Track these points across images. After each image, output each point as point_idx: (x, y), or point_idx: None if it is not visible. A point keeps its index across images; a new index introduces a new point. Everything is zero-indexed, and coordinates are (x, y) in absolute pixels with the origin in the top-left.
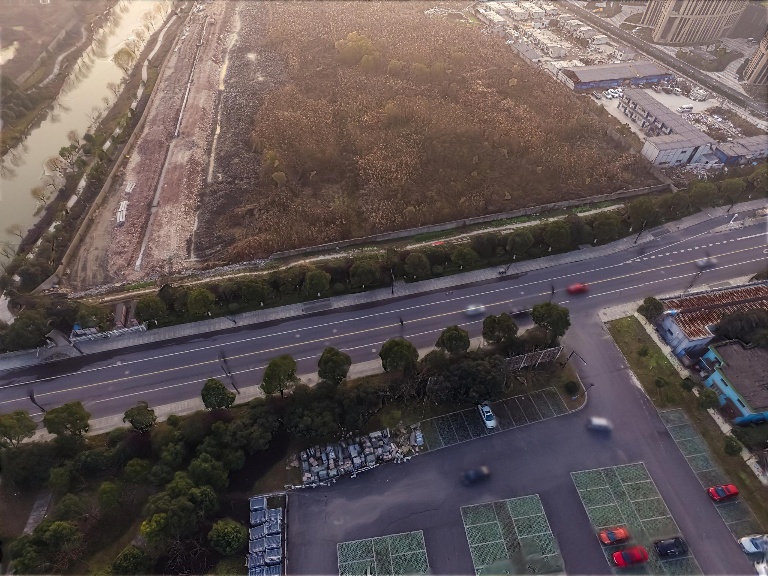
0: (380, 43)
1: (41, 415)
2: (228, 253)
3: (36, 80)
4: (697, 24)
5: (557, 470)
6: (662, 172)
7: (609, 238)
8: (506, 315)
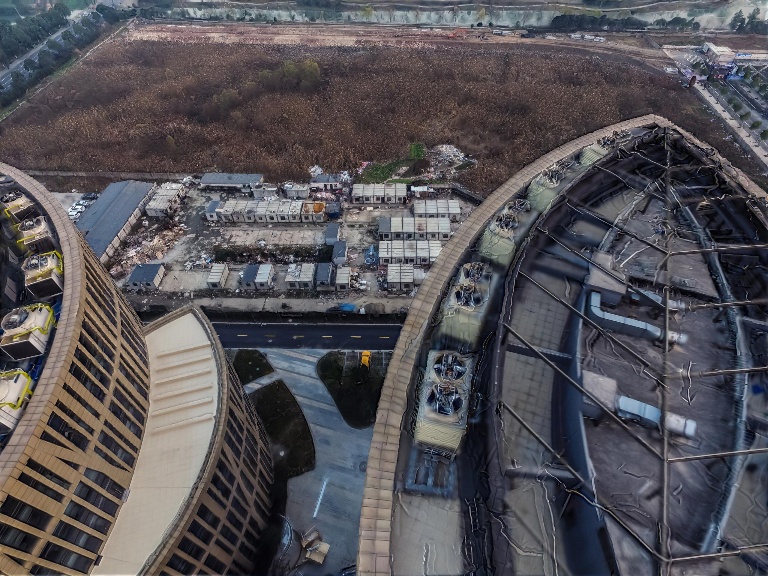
0: None
1: (78, 21)
2: None
3: (354, 1)
4: None
5: None
6: None
7: None
8: None
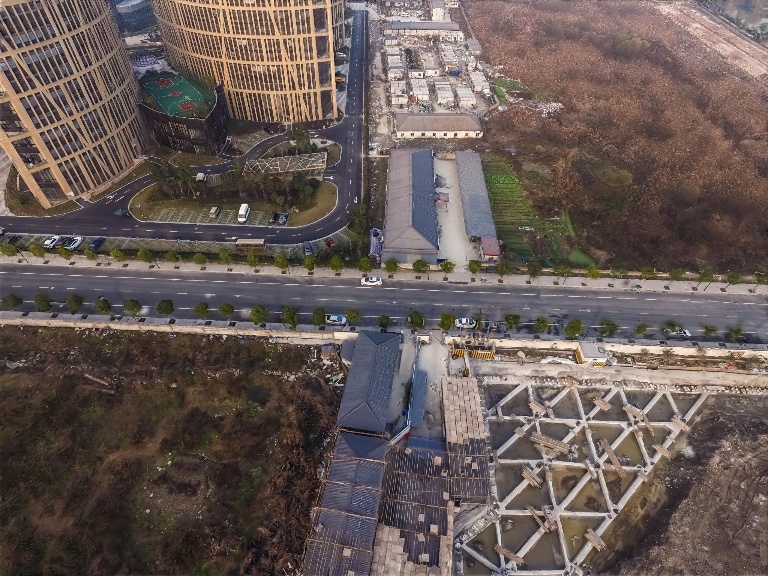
0: None
1: None
2: (640, 6)
3: None
4: None
5: None
6: None
7: None
8: None
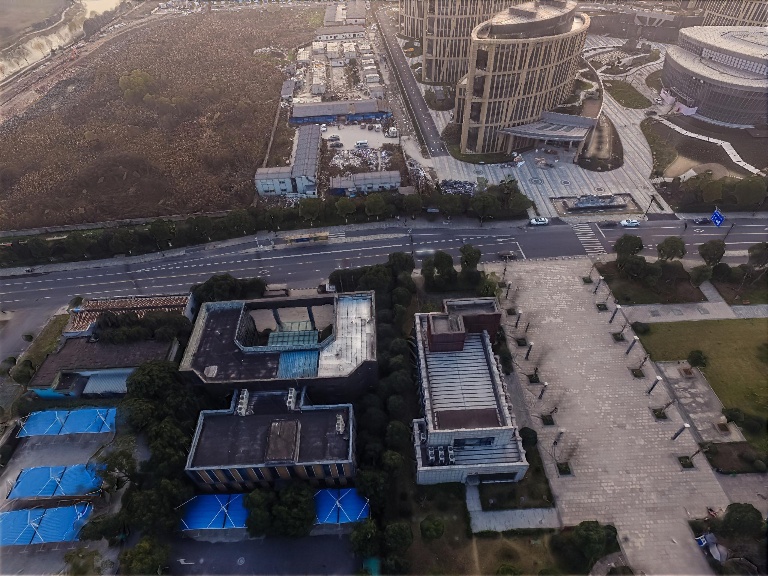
0: (160, 79)
1: None
2: None
3: None
4: (453, 65)
5: None
6: (265, 199)
7: (143, 251)
8: None
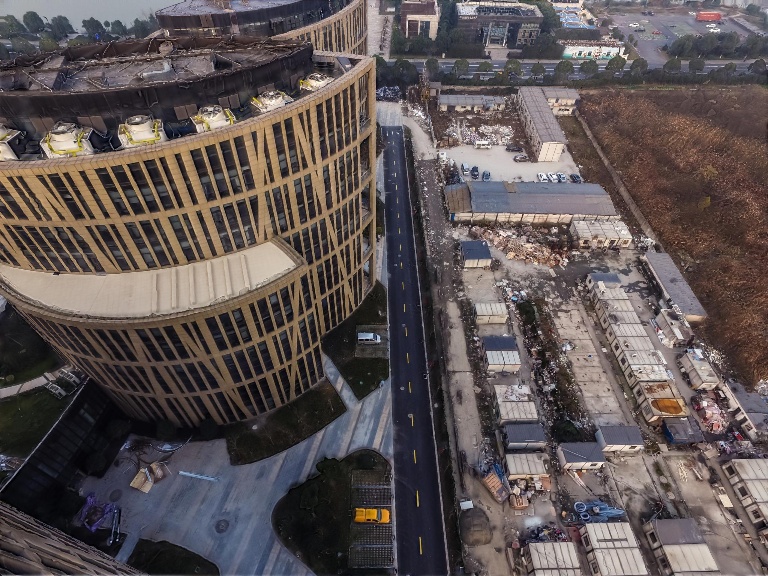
0: None
1: None
2: None
3: None
4: None
5: (673, 40)
6: None
7: None
8: (709, 38)
